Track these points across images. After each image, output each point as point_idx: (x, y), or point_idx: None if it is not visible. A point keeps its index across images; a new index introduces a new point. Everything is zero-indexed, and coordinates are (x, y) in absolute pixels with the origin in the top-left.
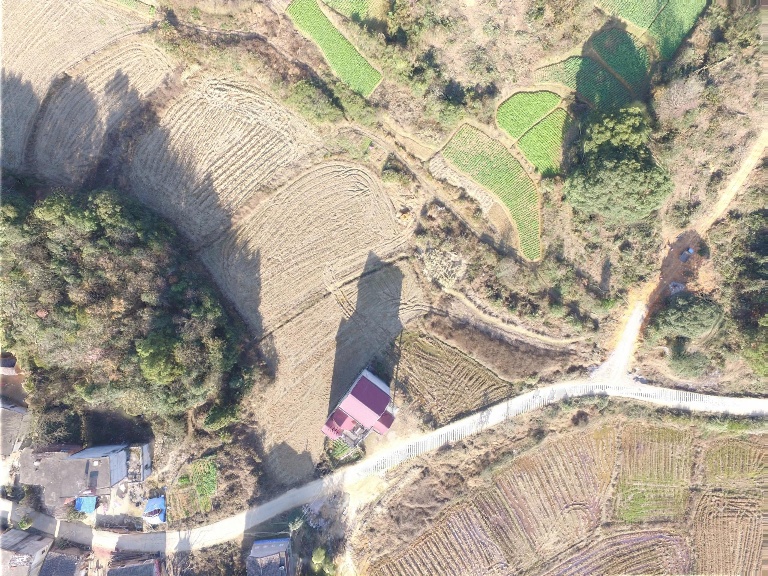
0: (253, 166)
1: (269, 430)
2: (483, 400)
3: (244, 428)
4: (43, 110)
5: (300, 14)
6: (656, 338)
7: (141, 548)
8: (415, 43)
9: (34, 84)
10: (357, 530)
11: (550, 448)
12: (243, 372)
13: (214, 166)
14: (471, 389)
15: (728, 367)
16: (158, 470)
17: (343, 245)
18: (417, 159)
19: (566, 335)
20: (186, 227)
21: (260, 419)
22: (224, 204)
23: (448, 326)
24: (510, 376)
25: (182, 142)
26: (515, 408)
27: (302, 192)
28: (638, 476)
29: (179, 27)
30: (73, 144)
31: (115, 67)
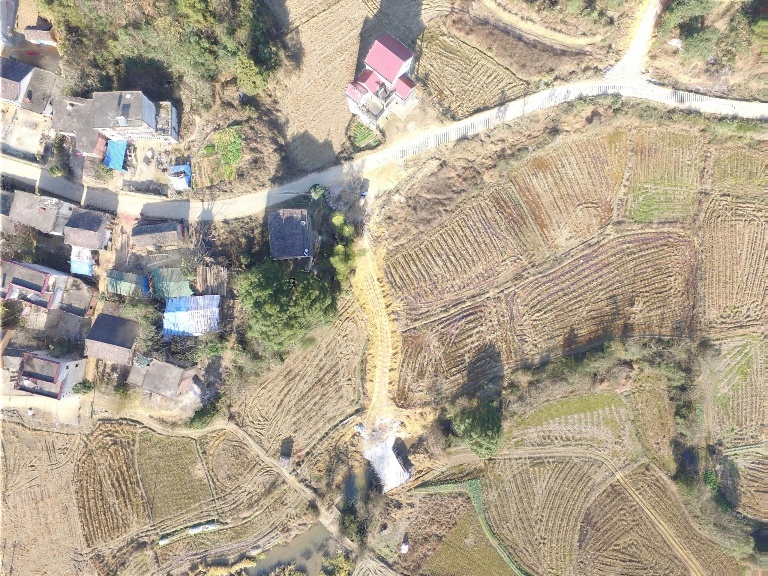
0: None
1: (292, 119)
2: (501, 97)
3: (268, 113)
4: None
5: None
6: (670, 27)
7: (165, 215)
8: None
9: None
10: (375, 216)
11: (564, 148)
12: (271, 44)
13: None
14: (489, 86)
15: (738, 64)
16: (185, 139)
17: None
18: None
19: (582, 33)
20: None
21: (284, 108)
22: None
23: (469, 24)
24: (528, 71)
25: None
26: (531, 105)
27: None
28: (649, 178)
29: None
30: None
31: None
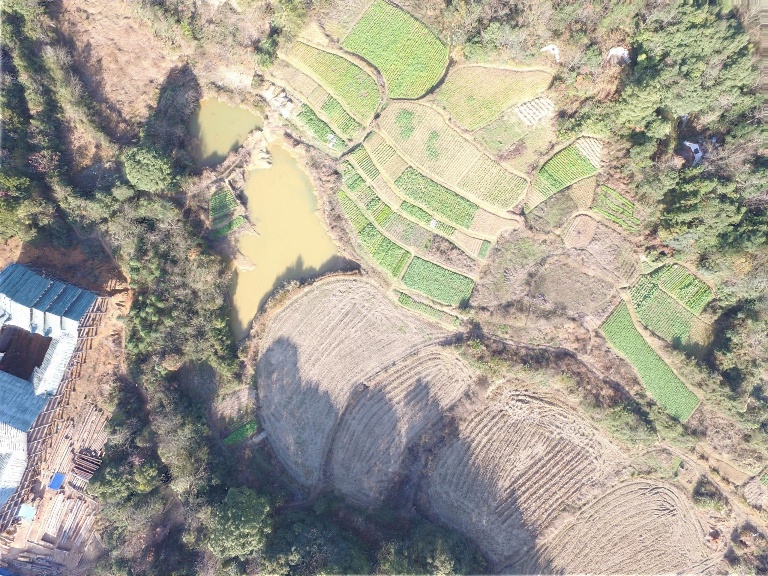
0: (558, 484)
1: None
2: None
3: None
4: (340, 422)
5: (615, 333)
6: None
7: None
8: (750, 382)
9: (331, 395)
10: None
11: None
12: None
13: (517, 483)
14: None
15: None
16: None
17: (649, 567)
18: (731, 483)
19: None
20: (488, 546)
21: None
22: (527, 523)
23: None
24: None
25: (483, 456)
26: None
27: (606, 510)
28: None
29: (486, 341)
30: (371, 458)
31: (414, 377)
